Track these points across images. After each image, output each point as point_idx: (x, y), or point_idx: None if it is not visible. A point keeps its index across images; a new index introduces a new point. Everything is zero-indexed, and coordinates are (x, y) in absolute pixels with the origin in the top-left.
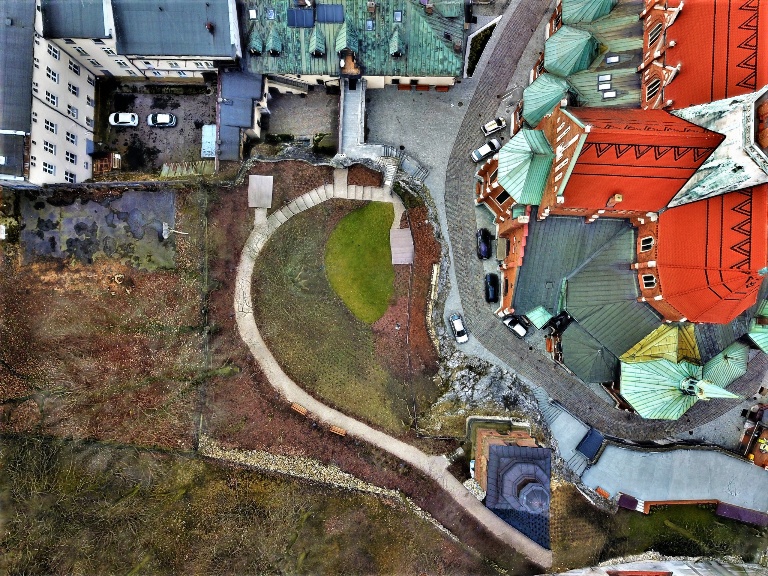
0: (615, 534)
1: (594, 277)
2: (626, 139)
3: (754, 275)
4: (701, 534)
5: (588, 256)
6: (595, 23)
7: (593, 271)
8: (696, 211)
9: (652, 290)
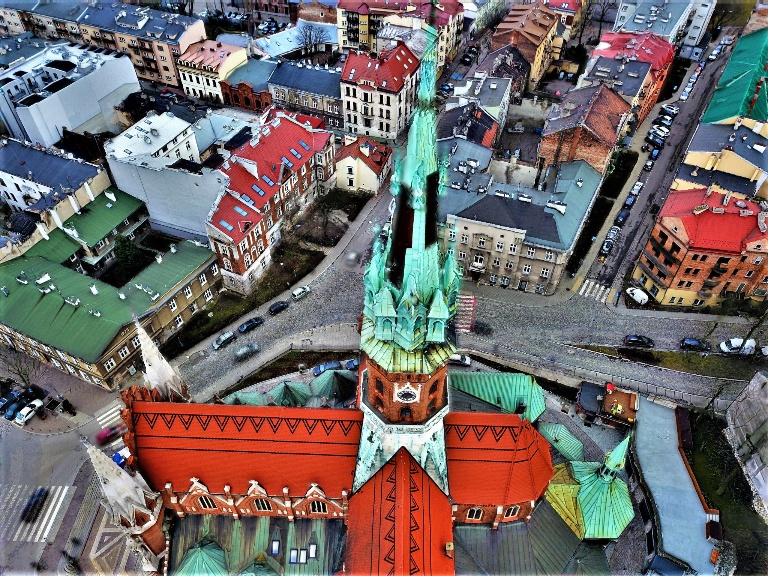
0: (756, 544)
1: (506, 568)
2: (406, 541)
3: (524, 424)
4: (717, 462)
5: (484, 575)
6: (230, 567)
7: (499, 569)
8: (457, 470)
9: (523, 509)
